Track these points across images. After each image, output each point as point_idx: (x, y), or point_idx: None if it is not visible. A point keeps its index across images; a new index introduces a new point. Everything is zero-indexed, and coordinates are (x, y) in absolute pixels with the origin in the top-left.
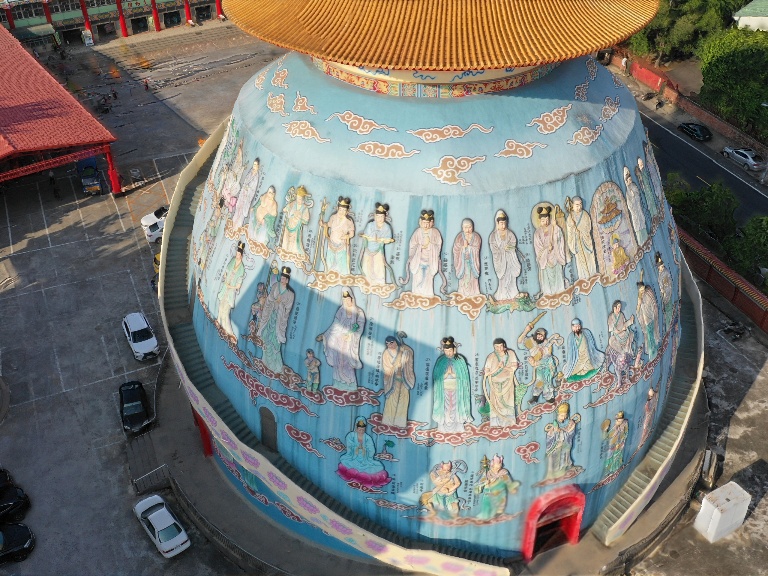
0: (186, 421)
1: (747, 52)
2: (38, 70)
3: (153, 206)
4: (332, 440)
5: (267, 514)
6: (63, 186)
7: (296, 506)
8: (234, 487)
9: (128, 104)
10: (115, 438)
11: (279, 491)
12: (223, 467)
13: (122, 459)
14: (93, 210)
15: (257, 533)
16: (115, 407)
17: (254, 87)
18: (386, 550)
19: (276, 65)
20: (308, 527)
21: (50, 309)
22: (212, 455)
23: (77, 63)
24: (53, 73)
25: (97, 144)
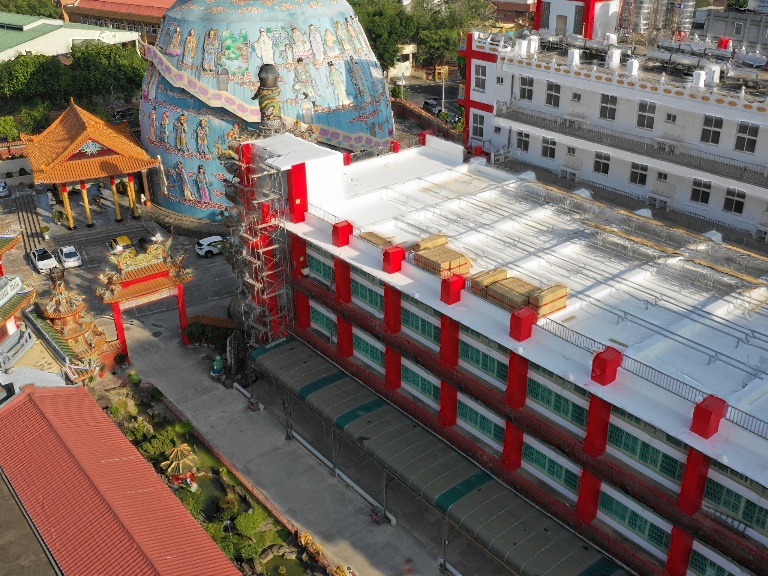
0: None
1: (49, 60)
2: None
3: None
4: None
5: None
6: None
7: None
8: None
9: None
10: None
11: None
12: None
13: None
14: None
15: None
16: None
17: (258, 13)
18: None
19: (249, 3)
20: None
21: None
22: None
23: None
24: None
25: None
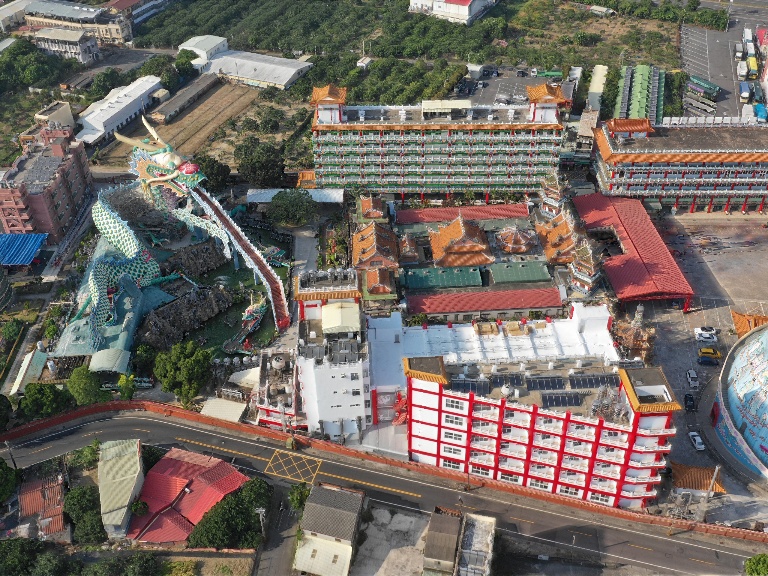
0: (707, 414)
1: None
2: (660, 240)
3: (699, 323)
4: (762, 437)
5: (730, 450)
6: (662, 300)
7: (745, 450)
8: (720, 439)
9: (690, 260)
10: (682, 410)
11: (741, 444)
12: (718, 432)
13: (684, 418)
14: (675, 316)
15: (725, 454)
16: (682, 400)
17: None
18: (766, 471)
19: None
20: (743, 458)
21: (659, 356)
22: (715, 427)
23: (666, 224)
24: (655, 227)
25: (687, 294)
